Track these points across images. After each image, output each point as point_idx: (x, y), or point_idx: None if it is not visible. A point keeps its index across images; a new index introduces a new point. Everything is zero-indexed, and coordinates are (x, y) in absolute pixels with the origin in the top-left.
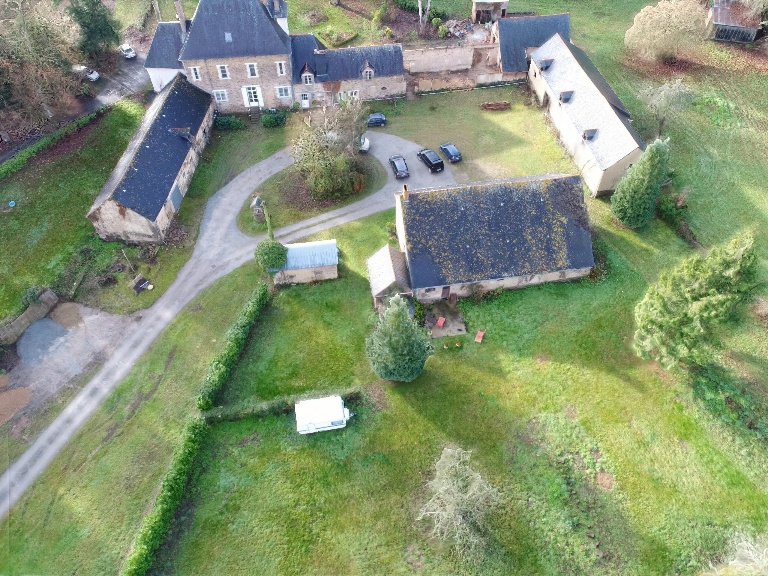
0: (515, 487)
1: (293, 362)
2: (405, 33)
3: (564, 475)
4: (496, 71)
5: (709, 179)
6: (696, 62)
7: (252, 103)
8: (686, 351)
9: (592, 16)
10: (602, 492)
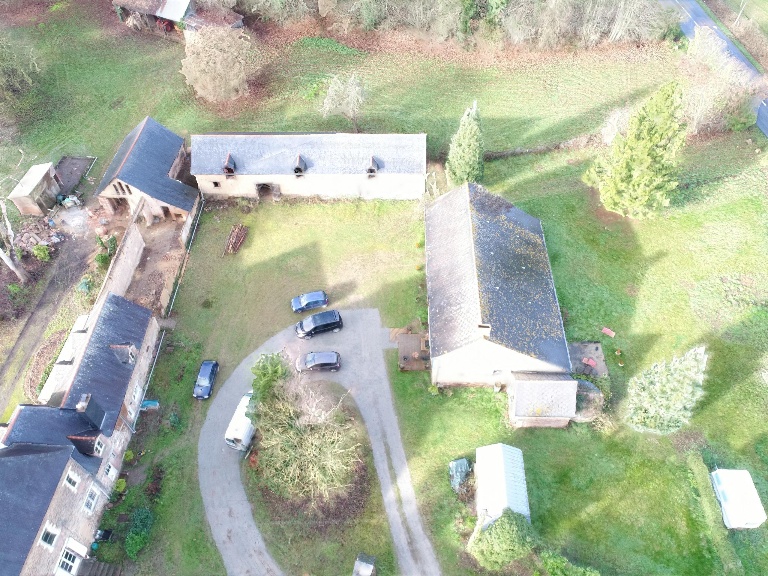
0: (765, 342)
1: (654, 531)
2: (6, 300)
3: (751, 304)
4: (167, 221)
5: (424, 121)
6: (252, 72)
7: (72, 570)
8: (675, 183)
9: (115, 111)
10: (758, 286)
